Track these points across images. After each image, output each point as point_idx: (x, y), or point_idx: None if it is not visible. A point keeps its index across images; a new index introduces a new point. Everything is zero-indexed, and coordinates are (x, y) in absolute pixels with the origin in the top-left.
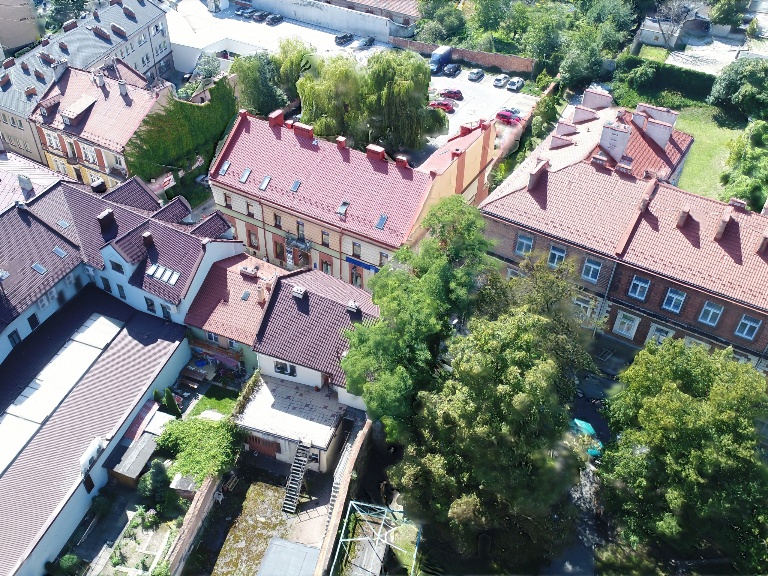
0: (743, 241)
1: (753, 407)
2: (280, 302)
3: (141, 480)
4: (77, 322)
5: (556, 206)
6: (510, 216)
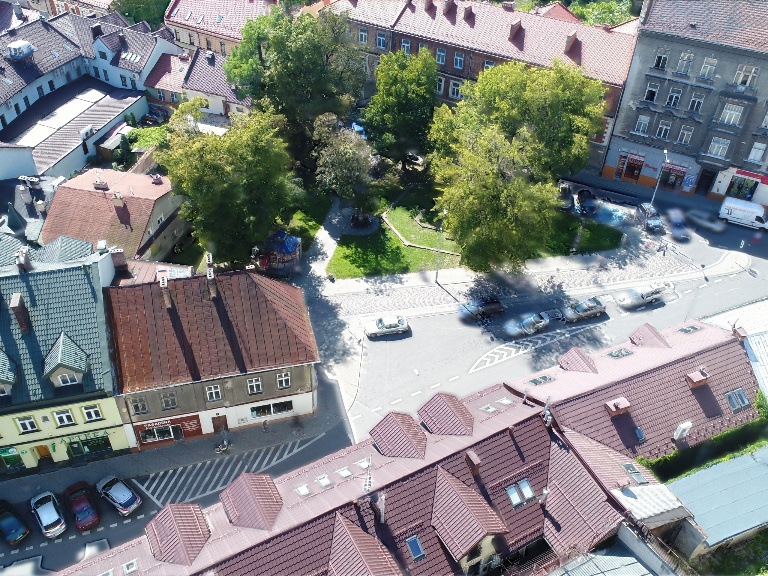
0: (458, 14)
1: (427, 70)
2: (199, 61)
3: (115, 151)
4: (78, 90)
5: (362, 5)
6: (336, 12)
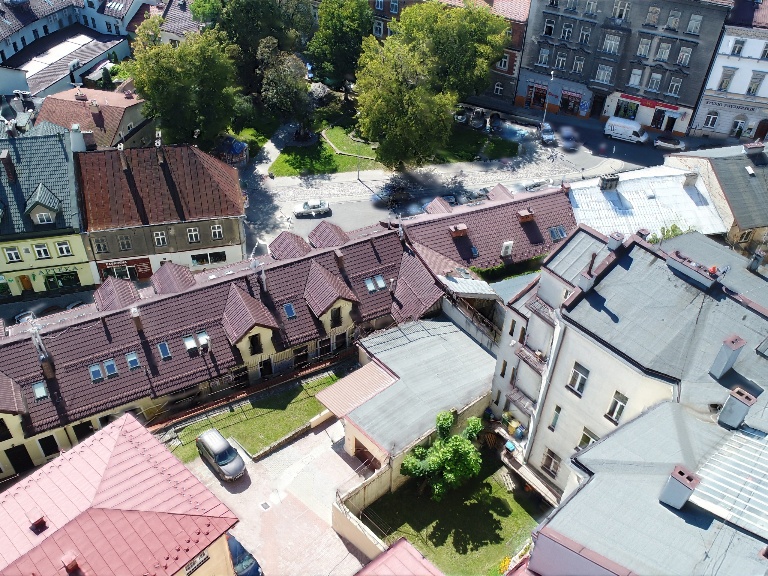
0: None
1: (360, 8)
2: (172, 7)
3: None
4: (69, 35)
5: None
6: None
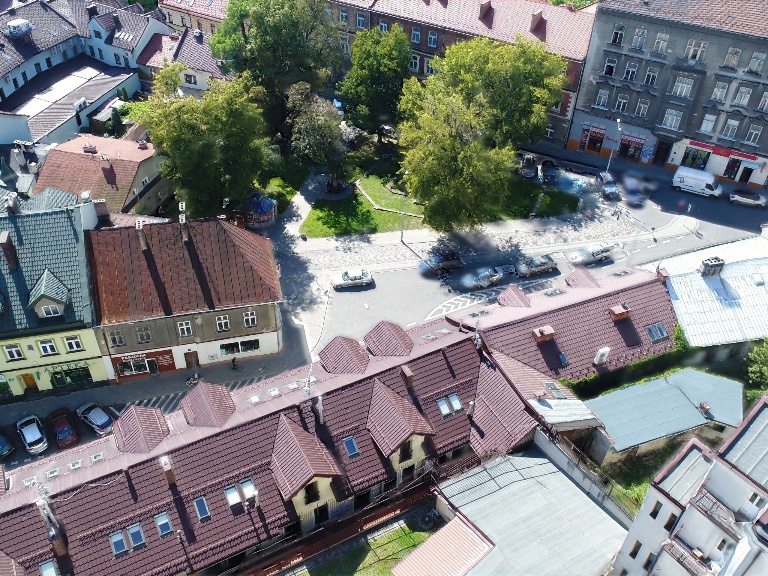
0: None
1: (399, 45)
2: (187, 39)
3: (107, 123)
4: (74, 68)
5: None
6: None
